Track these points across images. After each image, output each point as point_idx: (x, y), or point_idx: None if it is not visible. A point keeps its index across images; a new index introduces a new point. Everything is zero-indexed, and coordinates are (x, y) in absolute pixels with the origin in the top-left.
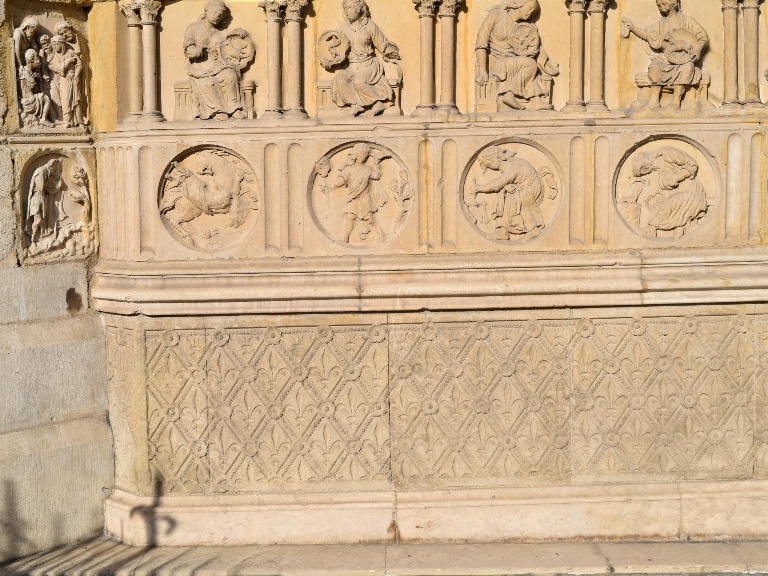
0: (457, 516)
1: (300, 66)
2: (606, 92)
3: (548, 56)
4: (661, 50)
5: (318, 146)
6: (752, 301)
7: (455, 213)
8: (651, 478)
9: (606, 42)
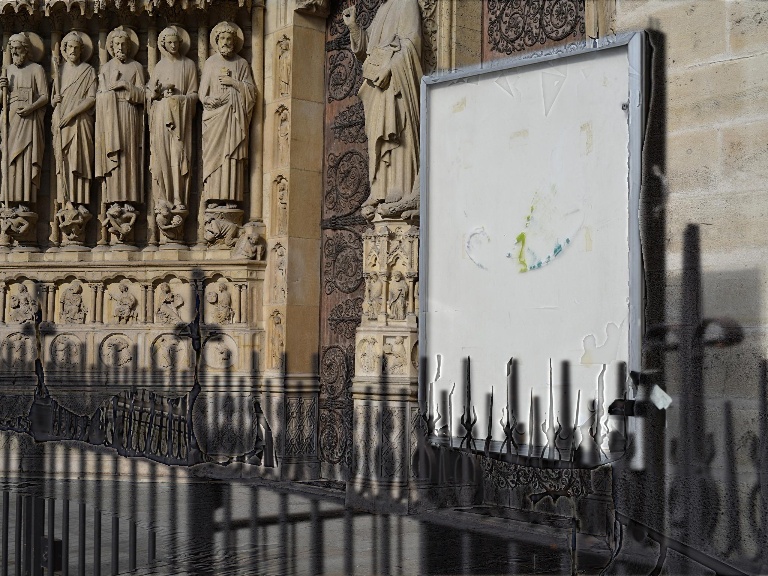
0: (42, 463)
1: (4, 307)
2: (104, 318)
3: (84, 305)
4: None
5: (5, 334)
6: None
7: (48, 358)
8: (110, 453)
9: (104, 301)
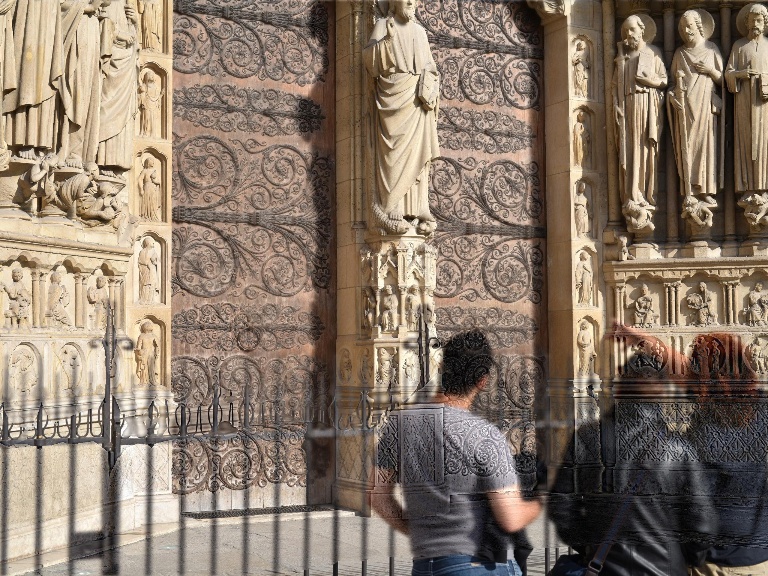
0: None
1: None
2: None
3: None
4: (15, 299)
5: None
6: None
7: None
8: None
9: None
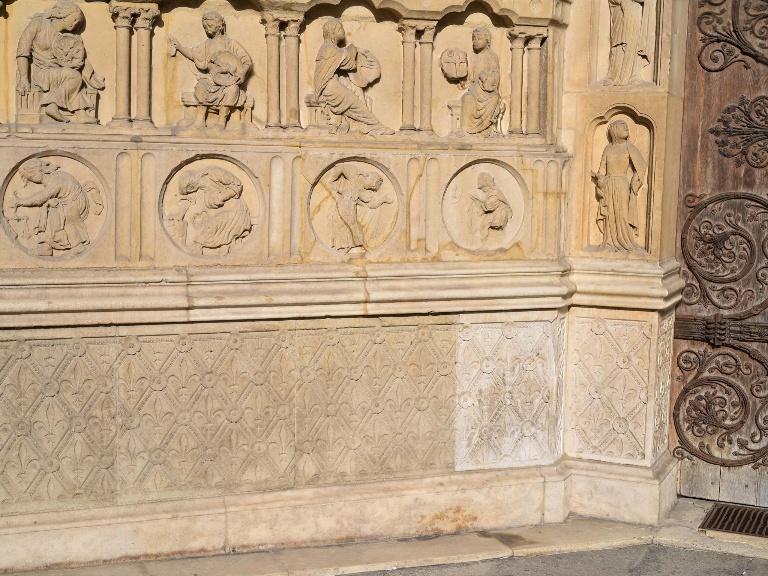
0: None
1: None
2: (153, 109)
3: (94, 69)
4: (207, 71)
5: None
6: (293, 317)
7: None
8: (197, 493)
9: (153, 59)
